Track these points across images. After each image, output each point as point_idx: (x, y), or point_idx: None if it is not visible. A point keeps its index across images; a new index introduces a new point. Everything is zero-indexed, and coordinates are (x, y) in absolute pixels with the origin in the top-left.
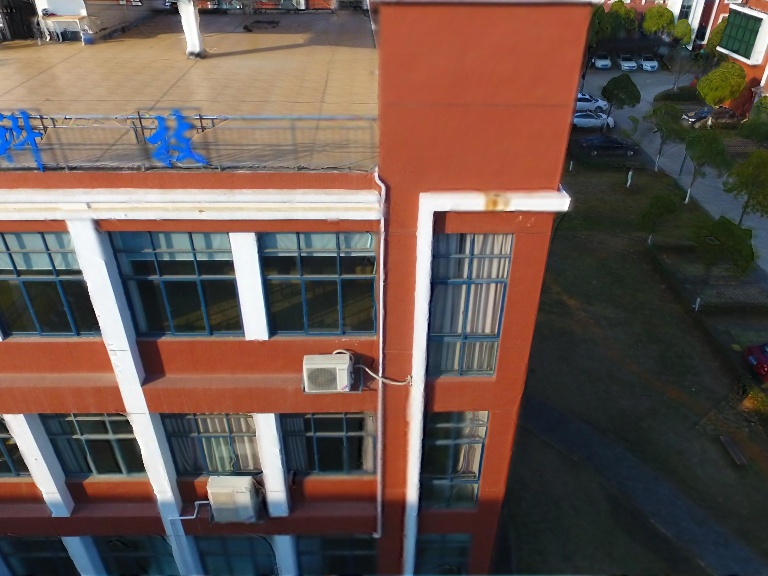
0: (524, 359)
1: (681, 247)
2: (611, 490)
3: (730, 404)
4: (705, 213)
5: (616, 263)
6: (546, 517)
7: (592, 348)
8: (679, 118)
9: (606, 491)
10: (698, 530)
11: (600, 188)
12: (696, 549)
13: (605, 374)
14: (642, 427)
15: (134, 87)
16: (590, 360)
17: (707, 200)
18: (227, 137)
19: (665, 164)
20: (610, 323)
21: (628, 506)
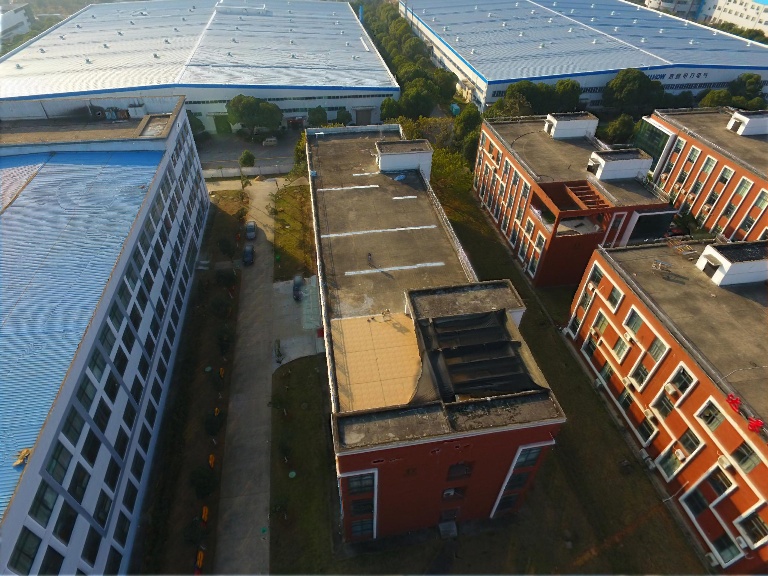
0: (341, 494)
1: None
2: None
3: None
4: None
5: None
6: (389, 567)
7: None
8: None
9: None
10: None
11: None
12: None
13: None
14: None
15: (390, 371)
16: None
17: None
18: (357, 403)
19: None
20: None
21: None
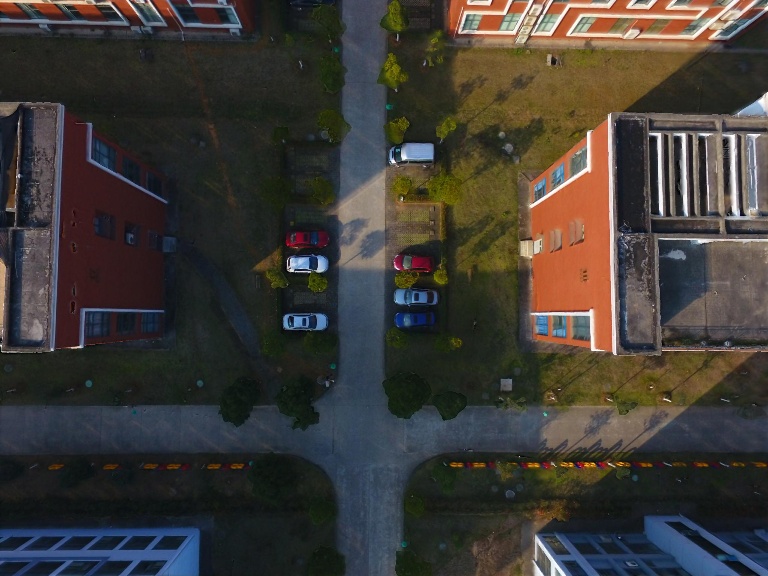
0: None
1: (302, 143)
2: (213, 294)
3: (272, 257)
4: (338, 99)
5: (262, 157)
6: (189, 303)
7: (229, 222)
8: (335, 16)
9: (211, 295)
10: (234, 310)
11: (284, 67)
12: (231, 316)
13: (229, 239)
14: (233, 268)
15: None
16: (226, 230)
17: (349, 81)
18: None
19: (346, 24)
20: (243, 206)
21: (216, 301)
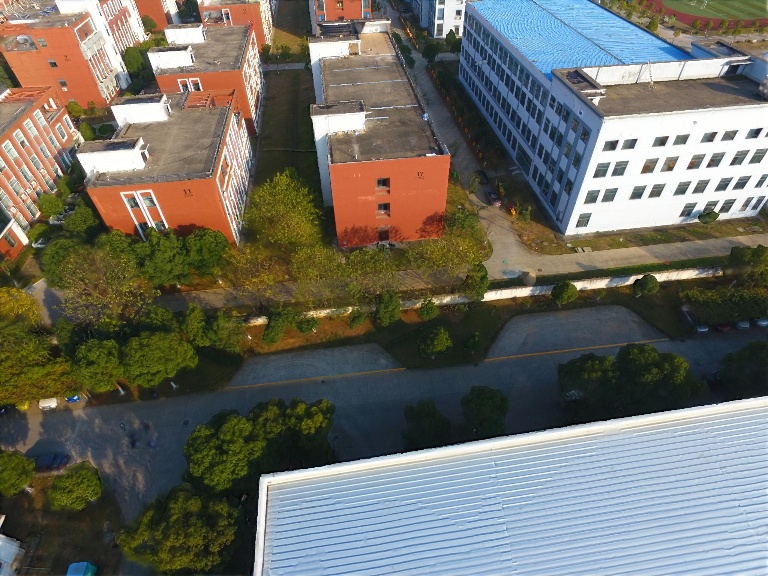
0: None
1: (309, 72)
2: None
3: None
4: (291, 69)
5: None
6: None
7: None
8: None
9: None
10: None
11: None
12: None
13: None
14: None
15: None
16: None
17: None
18: None
19: None
20: None
21: None
